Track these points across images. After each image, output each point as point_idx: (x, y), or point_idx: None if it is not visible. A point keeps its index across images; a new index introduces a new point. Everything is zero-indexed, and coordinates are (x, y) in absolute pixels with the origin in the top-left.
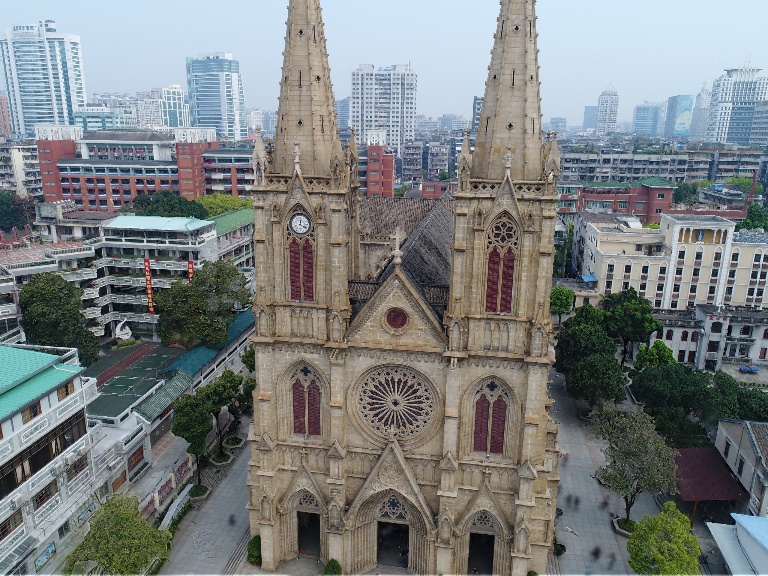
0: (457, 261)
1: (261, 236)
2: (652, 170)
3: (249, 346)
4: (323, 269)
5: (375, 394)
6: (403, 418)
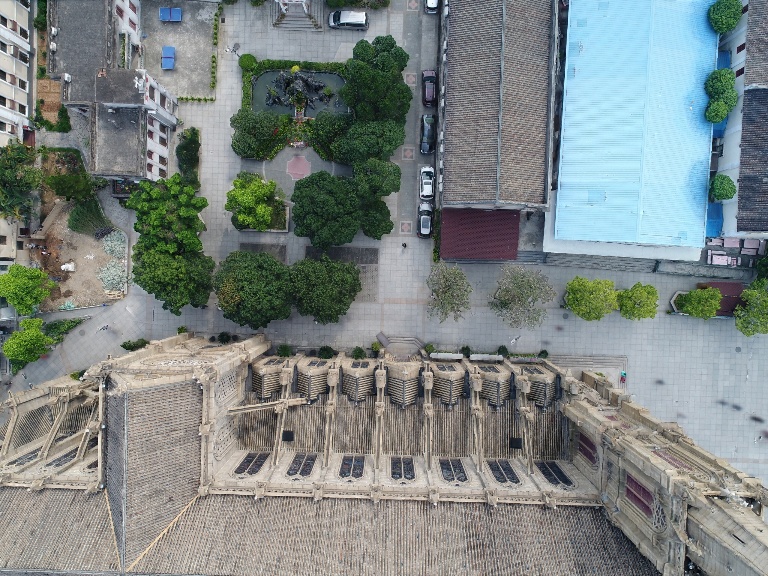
0: None
1: None
2: None
3: None
4: None
5: None
6: None
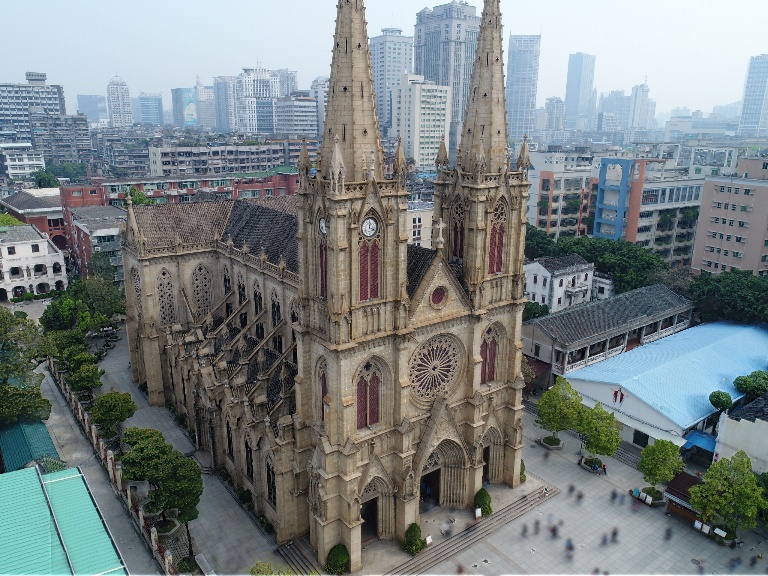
0: (479, 239)
1: (344, 244)
2: (254, 159)
3: (98, 401)
4: (391, 265)
5: (421, 366)
6: (439, 379)
